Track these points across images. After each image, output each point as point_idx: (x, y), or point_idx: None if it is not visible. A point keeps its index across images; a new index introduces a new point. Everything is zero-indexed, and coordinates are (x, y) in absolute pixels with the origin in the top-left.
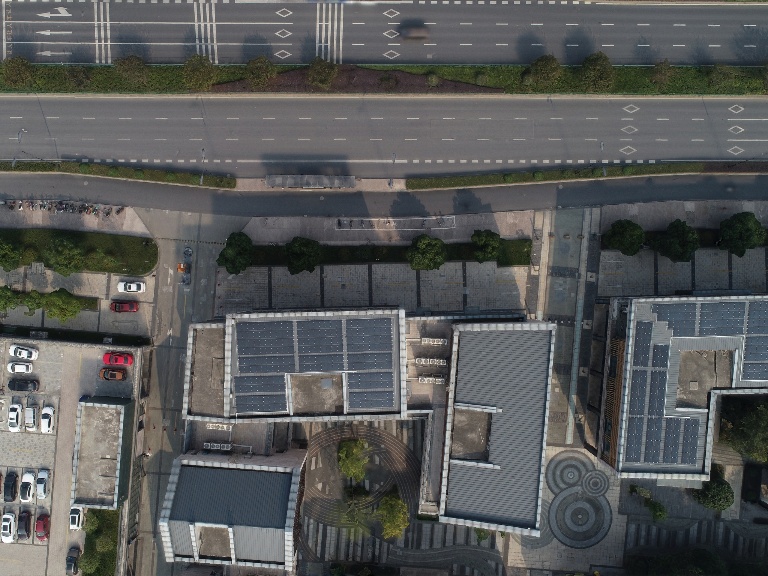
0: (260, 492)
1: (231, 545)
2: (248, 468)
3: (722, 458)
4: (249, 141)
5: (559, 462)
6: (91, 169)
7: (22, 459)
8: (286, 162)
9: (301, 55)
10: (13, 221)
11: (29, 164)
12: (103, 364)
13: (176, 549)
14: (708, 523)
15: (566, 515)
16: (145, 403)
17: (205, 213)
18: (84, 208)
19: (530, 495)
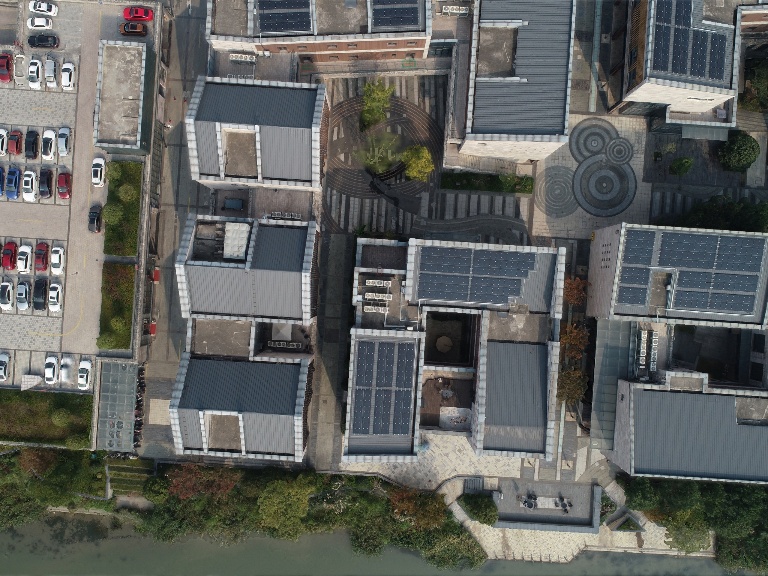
0: (286, 103)
1: (257, 152)
2: (273, 84)
3: (746, 125)
4: None
5: (582, 130)
6: None
7: (43, 118)
8: None
9: None
10: None
11: None
12: (123, 21)
13: (201, 165)
14: (733, 190)
15: (590, 183)
16: (165, 73)
17: None
18: None
19: (558, 104)
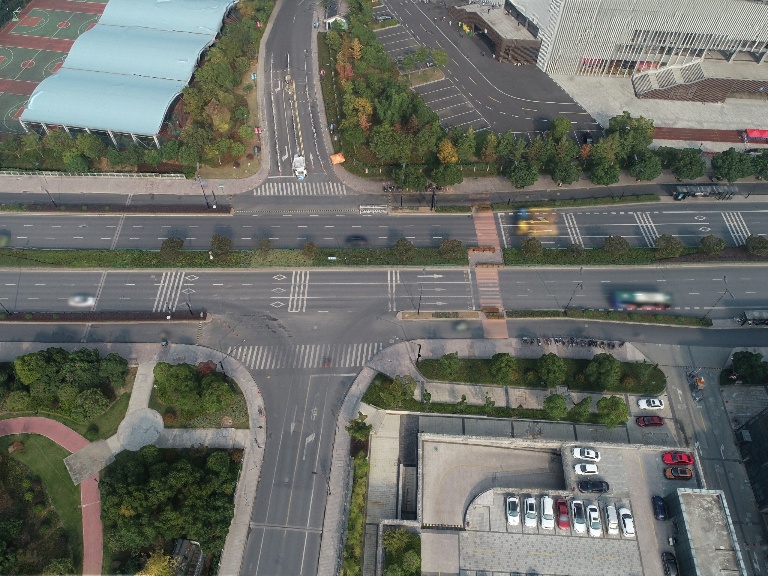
0: None
1: None
2: None
3: None
4: (708, 294)
5: None
6: (592, 314)
7: (608, 569)
8: (743, 308)
9: (724, 241)
10: (533, 354)
11: (540, 312)
12: (662, 465)
13: None
14: None
15: None
16: None
17: (692, 345)
18: (593, 342)
19: None
